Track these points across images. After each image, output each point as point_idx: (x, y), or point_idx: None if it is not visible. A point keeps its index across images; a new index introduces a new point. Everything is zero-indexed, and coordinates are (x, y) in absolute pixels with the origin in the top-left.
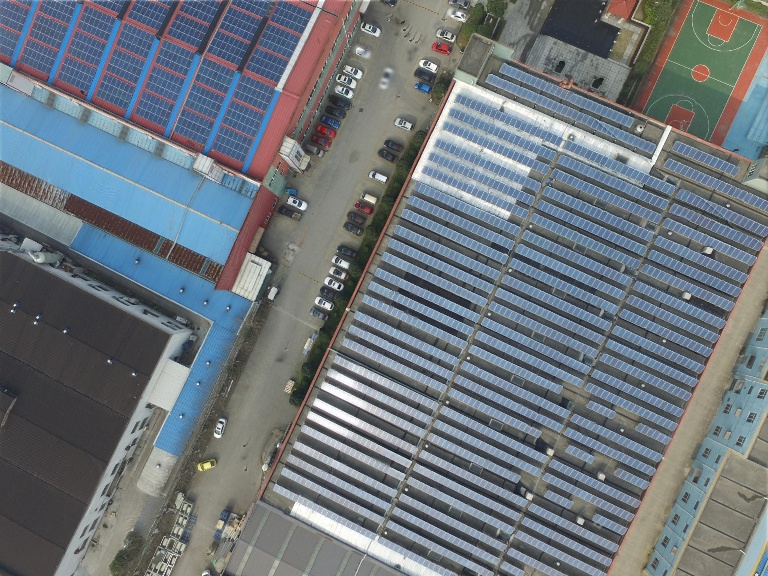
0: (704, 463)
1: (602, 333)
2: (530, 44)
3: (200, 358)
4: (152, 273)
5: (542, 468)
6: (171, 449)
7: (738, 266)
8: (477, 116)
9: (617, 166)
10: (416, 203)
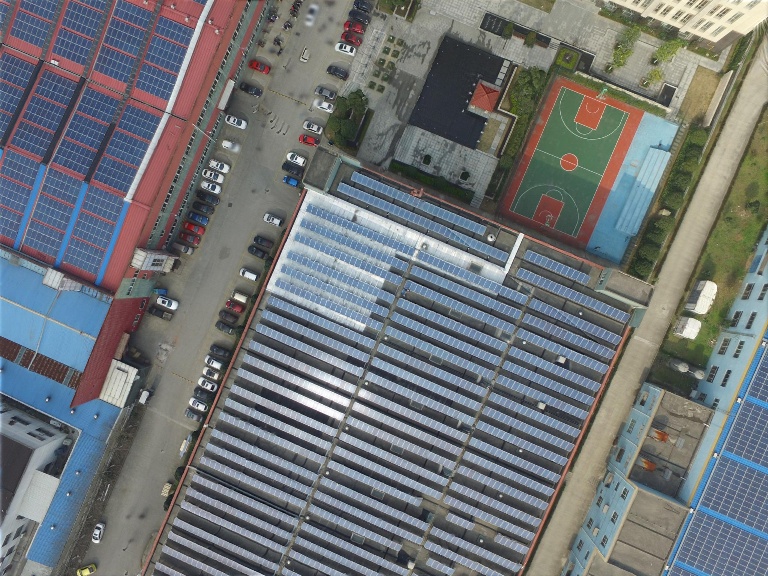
0: (577, 556)
1: (460, 444)
2: (399, 134)
3: (69, 468)
4: (17, 382)
5: None
6: (44, 561)
7: (592, 373)
8: (330, 225)
9: (470, 276)
10: (270, 317)
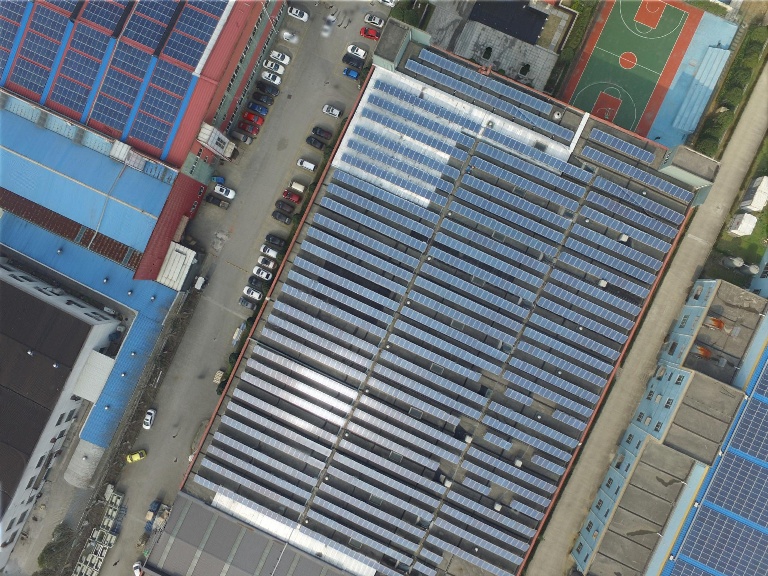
0: (627, 449)
1: (520, 321)
2: (459, 30)
3: (125, 349)
4: (75, 263)
5: (461, 455)
6: (97, 441)
7: (654, 253)
8: (397, 102)
9: (535, 153)
10: (335, 191)
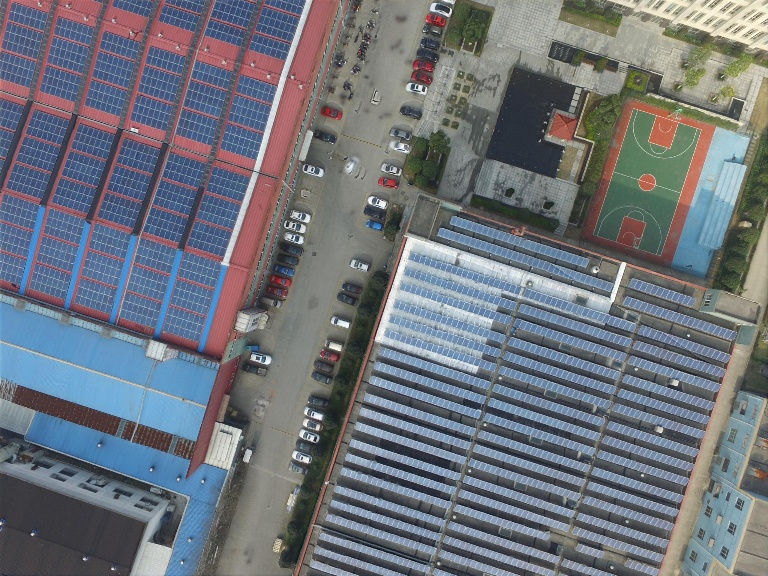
0: (692, 568)
1: (582, 474)
2: (477, 169)
3: (180, 536)
4: (117, 455)
5: None
6: None
7: (704, 392)
8: (433, 271)
9: (578, 309)
10: (382, 368)
